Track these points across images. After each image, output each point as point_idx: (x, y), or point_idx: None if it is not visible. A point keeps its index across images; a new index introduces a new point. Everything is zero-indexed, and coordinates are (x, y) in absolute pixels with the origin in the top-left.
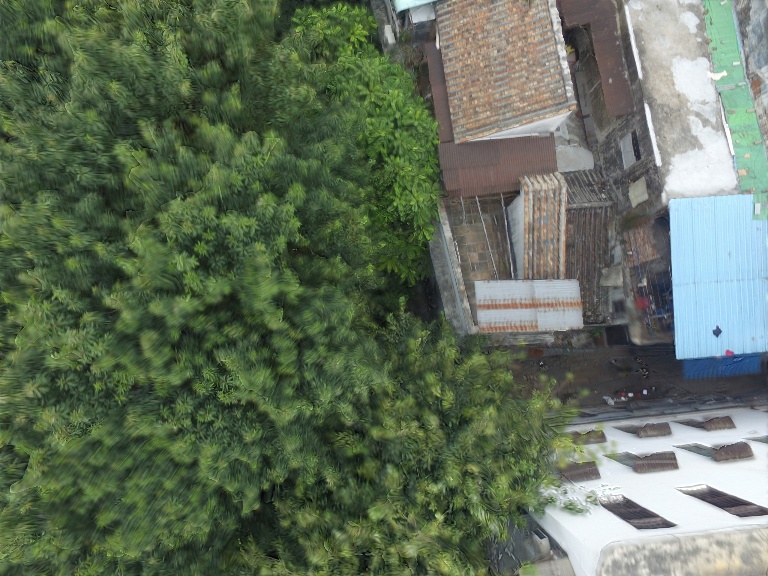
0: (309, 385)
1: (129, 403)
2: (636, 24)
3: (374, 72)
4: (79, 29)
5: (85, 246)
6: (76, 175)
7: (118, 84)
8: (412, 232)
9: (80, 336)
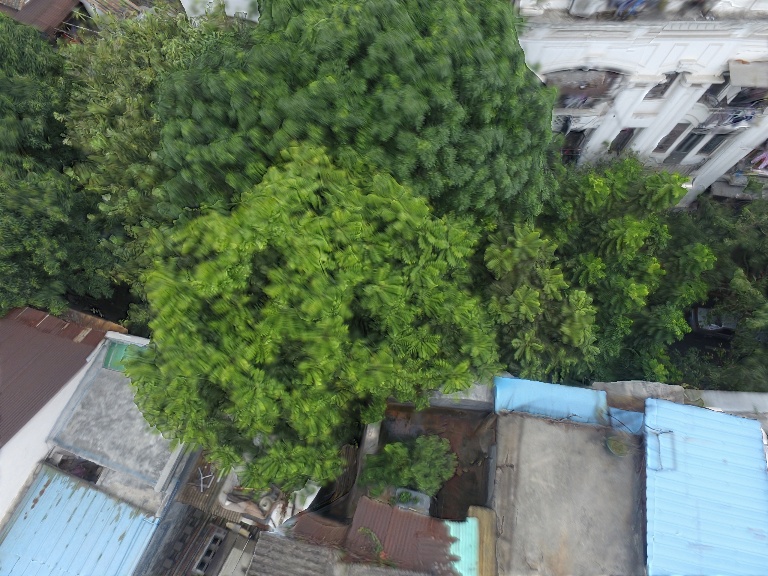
0: None
1: None
2: None
3: None
4: None
5: None
6: None
7: None
8: None
9: None
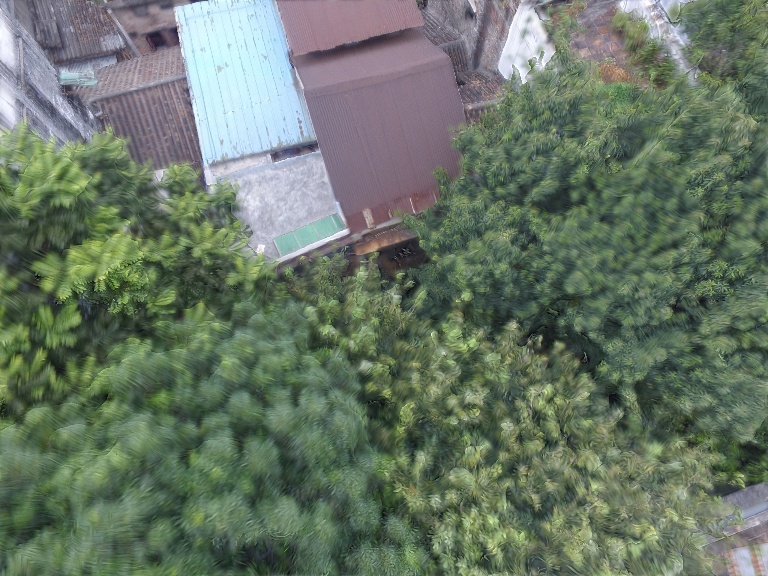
0: None
1: None
2: None
3: None
4: None
5: None
6: None
7: None
8: (761, 463)
9: None
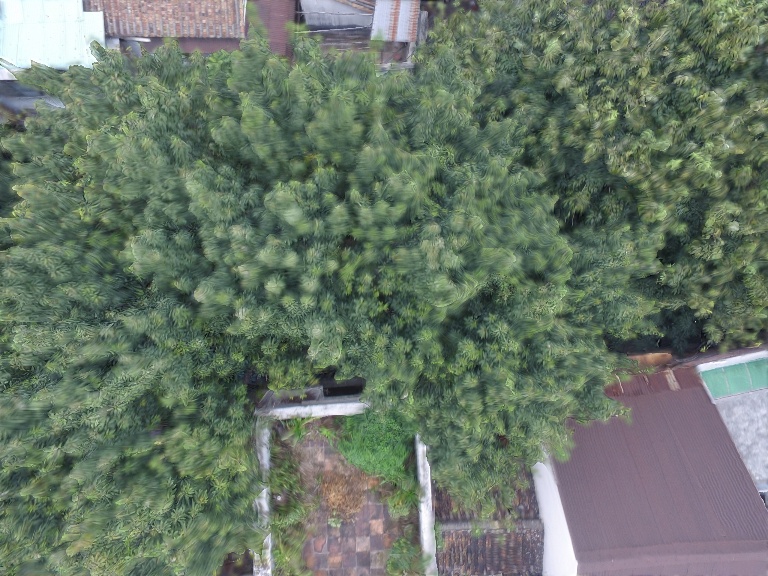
0: None
1: (451, 203)
2: None
3: None
4: None
5: (317, 189)
6: (248, 208)
7: (177, 139)
8: None
9: None
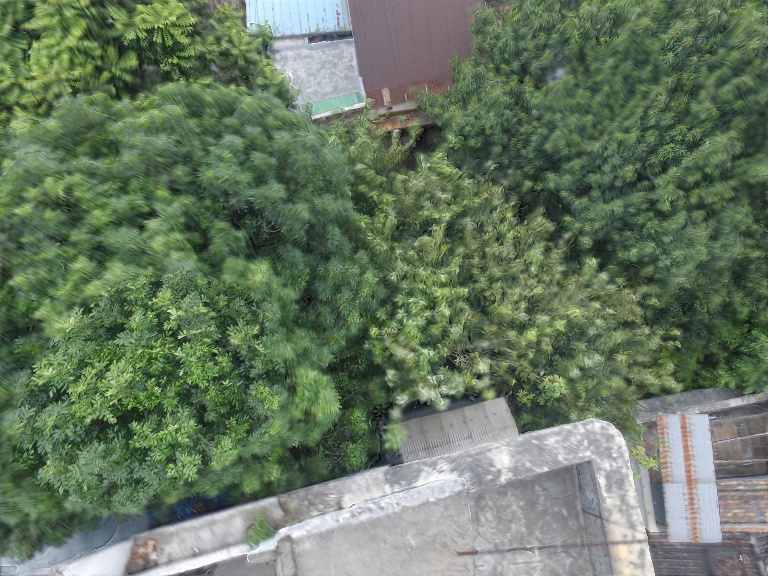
0: (672, 215)
1: None
2: None
3: None
4: None
5: None
6: None
7: None
8: (714, 373)
9: (767, 31)
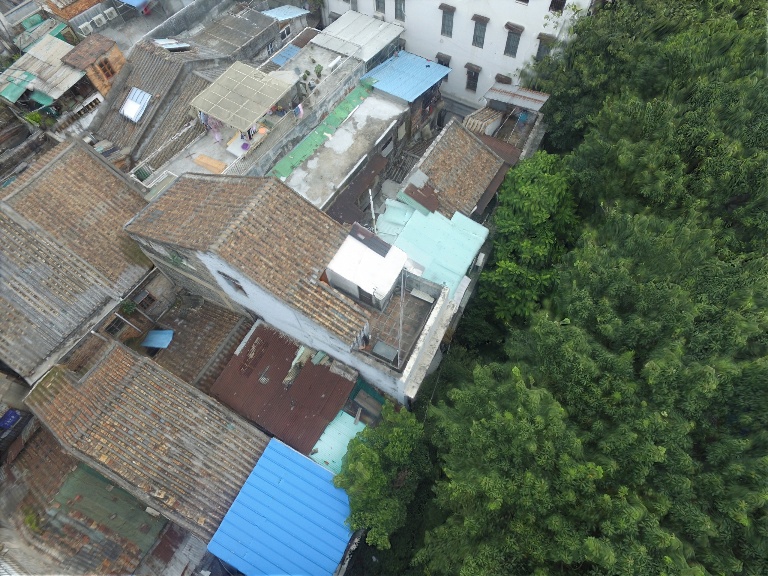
0: None
1: None
2: (342, 177)
3: (534, 196)
4: (744, 83)
5: None
6: None
7: None
8: None
9: None
